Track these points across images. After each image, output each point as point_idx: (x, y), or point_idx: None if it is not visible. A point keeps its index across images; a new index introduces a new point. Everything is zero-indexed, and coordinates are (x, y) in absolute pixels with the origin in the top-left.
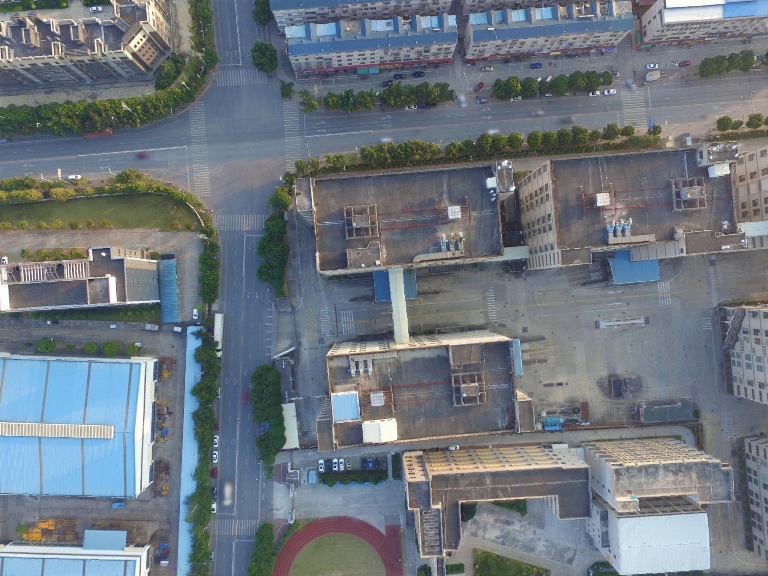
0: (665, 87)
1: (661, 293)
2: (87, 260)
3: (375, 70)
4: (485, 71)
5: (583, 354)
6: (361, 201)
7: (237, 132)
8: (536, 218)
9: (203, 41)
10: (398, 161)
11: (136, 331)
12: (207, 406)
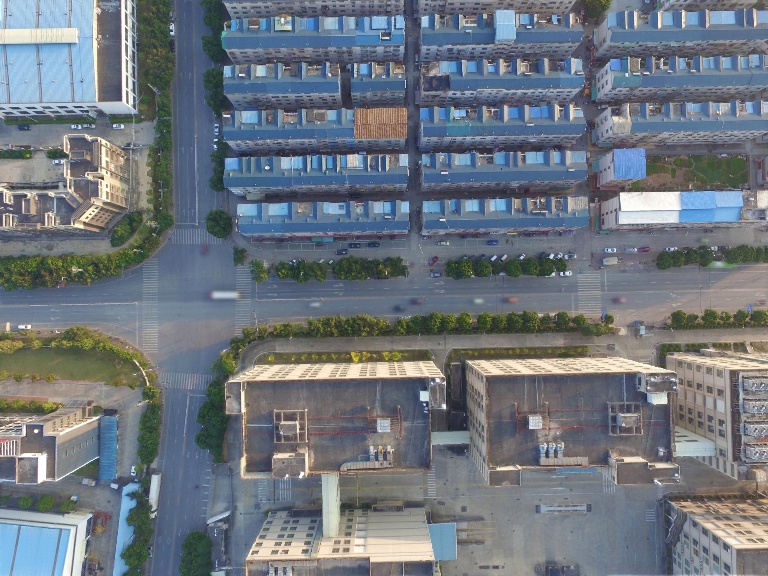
0: (622, 271)
1: (605, 481)
2: (19, 438)
3: (330, 239)
4: (441, 245)
5: (522, 538)
6: (292, 404)
7: (189, 291)
8: (475, 415)
9: (160, 203)
10: (345, 334)
11: (74, 483)
12: (136, 570)
